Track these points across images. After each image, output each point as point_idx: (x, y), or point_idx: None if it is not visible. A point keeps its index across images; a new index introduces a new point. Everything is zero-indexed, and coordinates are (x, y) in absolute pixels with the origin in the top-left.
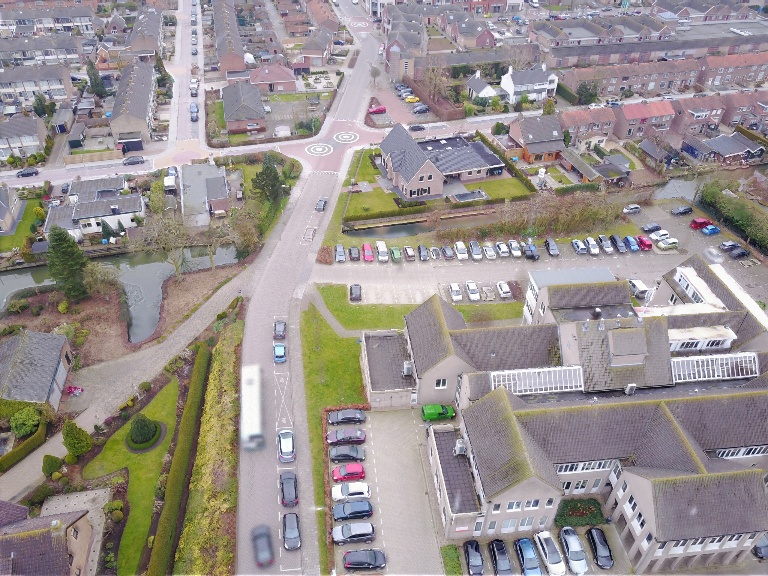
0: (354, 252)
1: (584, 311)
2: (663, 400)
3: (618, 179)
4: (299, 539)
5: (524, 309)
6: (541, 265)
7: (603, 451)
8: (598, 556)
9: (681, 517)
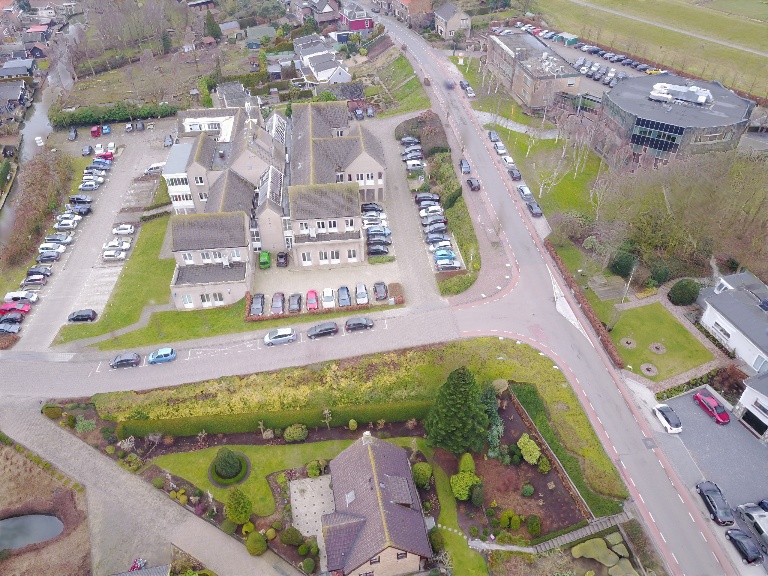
0: (13, 315)
1: (217, 159)
2: (311, 138)
3: (3, 151)
4: (366, 318)
5: (175, 205)
6: (100, 209)
7: (332, 173)
8: (378, 208)
9: (377, 156)
